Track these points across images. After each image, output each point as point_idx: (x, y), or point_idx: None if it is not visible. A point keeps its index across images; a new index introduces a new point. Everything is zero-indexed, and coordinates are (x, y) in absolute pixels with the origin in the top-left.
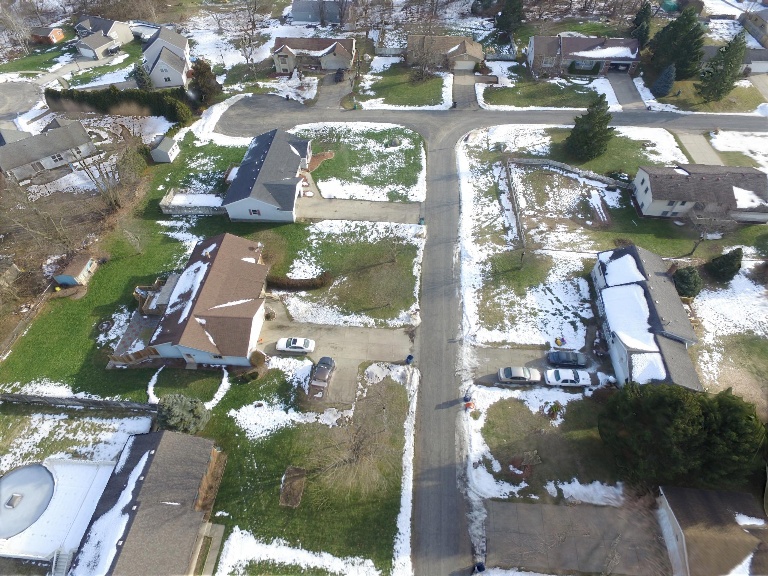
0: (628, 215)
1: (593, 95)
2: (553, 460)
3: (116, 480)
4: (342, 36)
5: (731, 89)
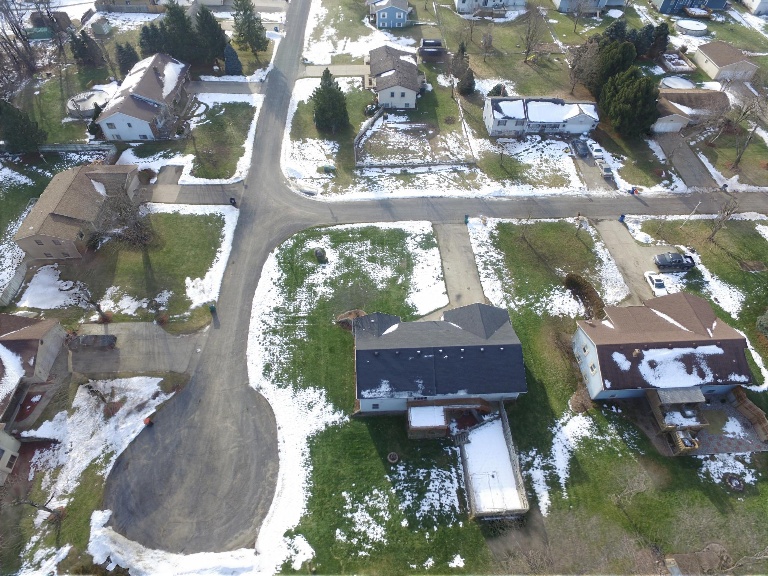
0: (416, 114)
1: (230, 106)
2: None
3: None
4: None
5: (265, 33)
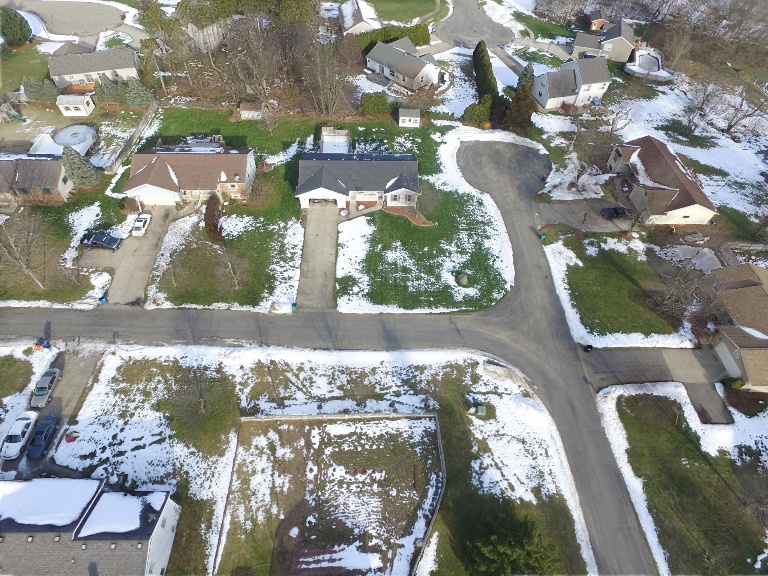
0: None
1: None
2: None
3: None
4: (758, 209)
5: None
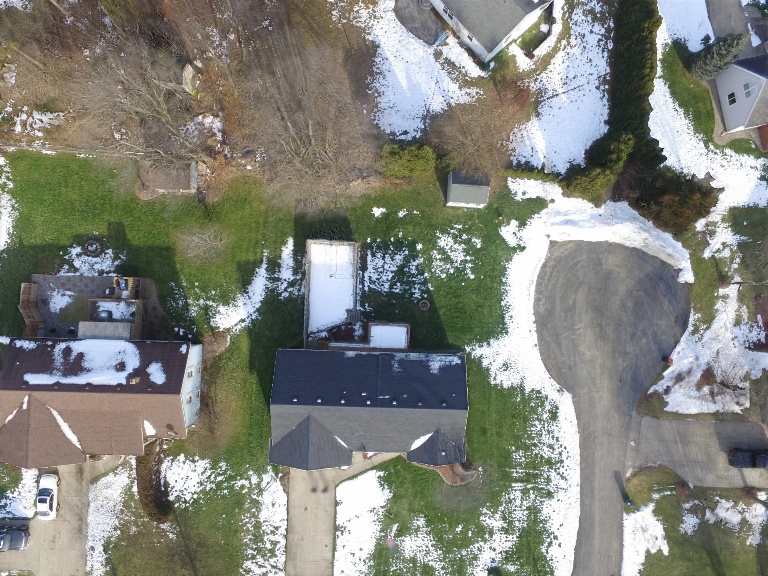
0: None
1: None
2: None
3: None
4: None
5: None
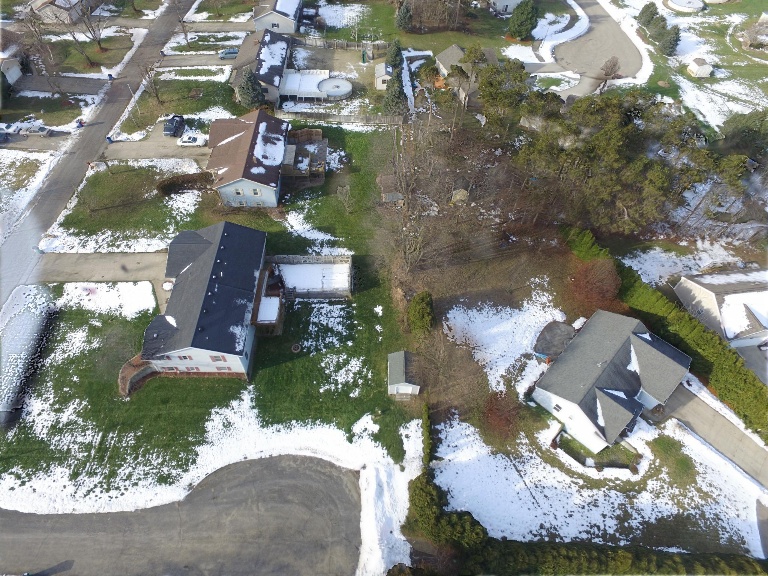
0: None
1: None
2: (47, 103)
3: (276, 73)
4: None
5: None
